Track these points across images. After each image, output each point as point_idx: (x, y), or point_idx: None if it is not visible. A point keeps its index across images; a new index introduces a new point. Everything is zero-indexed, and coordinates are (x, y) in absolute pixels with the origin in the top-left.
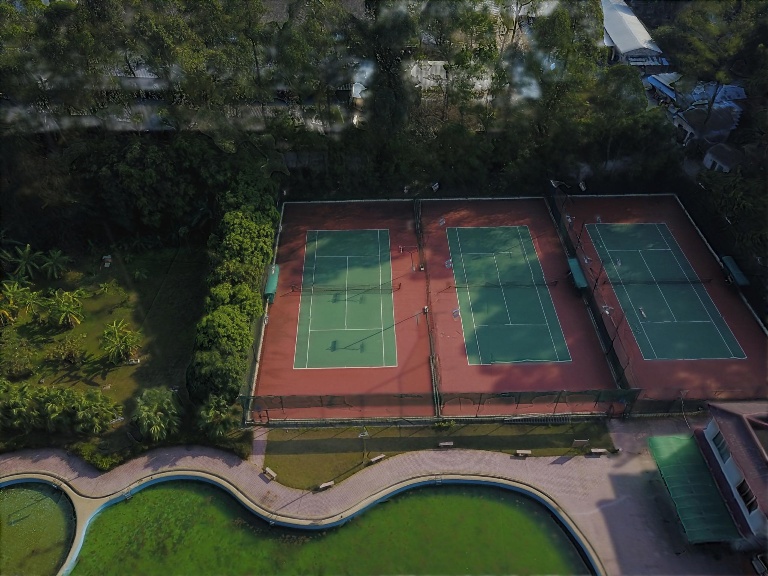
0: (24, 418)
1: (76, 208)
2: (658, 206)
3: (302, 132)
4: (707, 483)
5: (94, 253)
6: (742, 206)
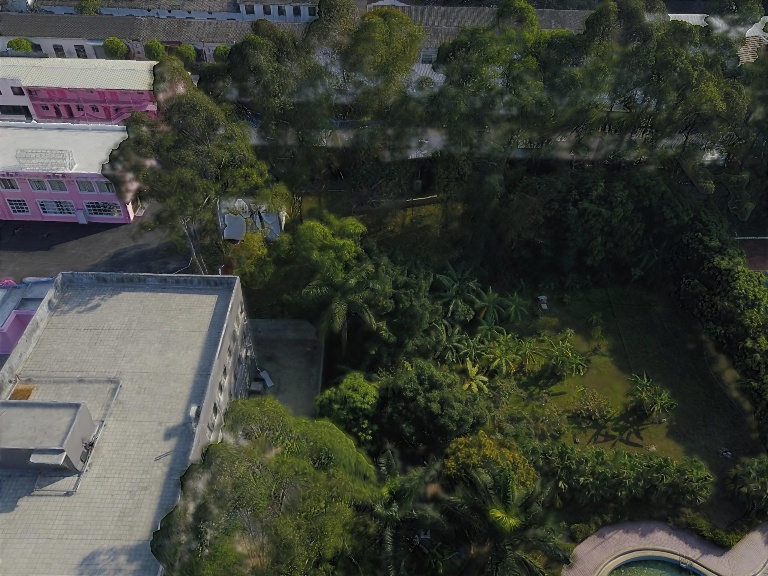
0: (625, 488)
1: (532, 247)
2: None
3: (715, 167)
4: None
5: (524, 293)
6: None
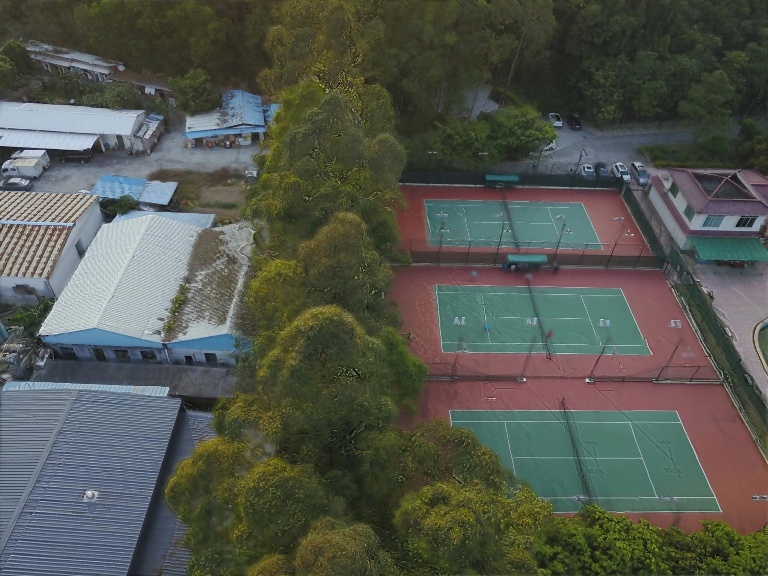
0: None
1: None
2: None
3: None
4: (727, 241)
5: None
6: (480, 139)
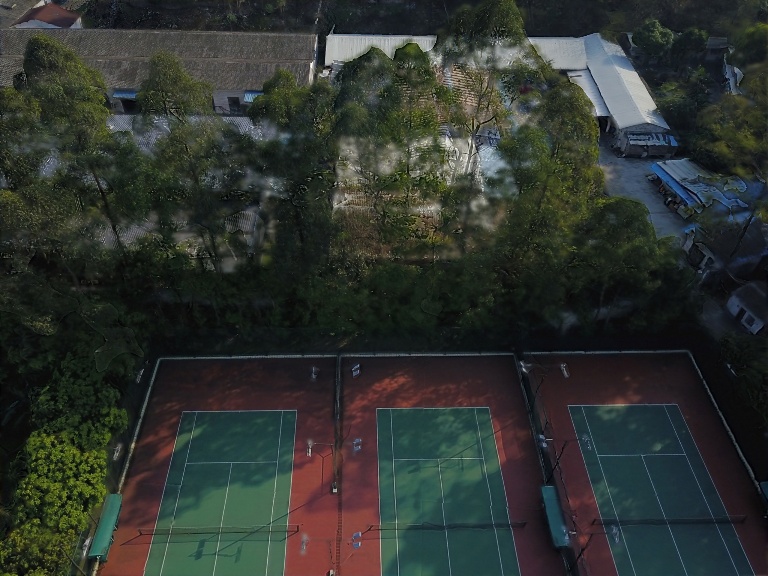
0: None
1: None
2: (667, 372)
3: (179, 270)
4: None
5: None
6: None
